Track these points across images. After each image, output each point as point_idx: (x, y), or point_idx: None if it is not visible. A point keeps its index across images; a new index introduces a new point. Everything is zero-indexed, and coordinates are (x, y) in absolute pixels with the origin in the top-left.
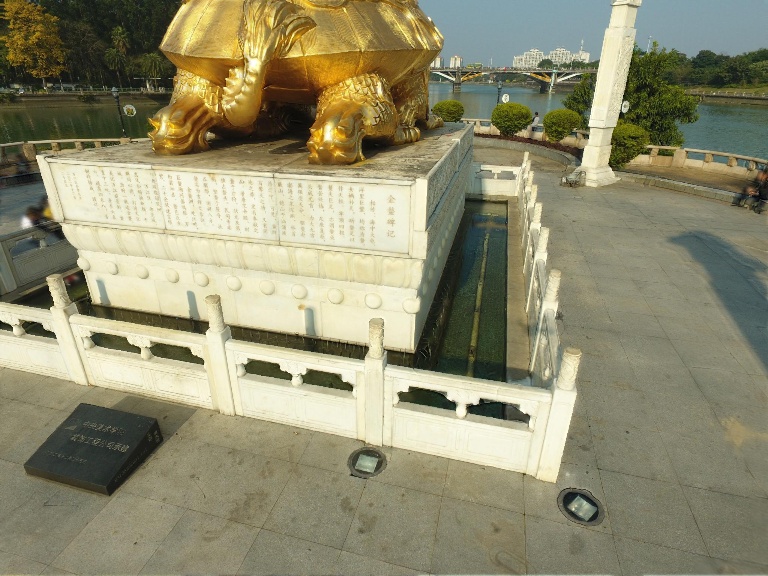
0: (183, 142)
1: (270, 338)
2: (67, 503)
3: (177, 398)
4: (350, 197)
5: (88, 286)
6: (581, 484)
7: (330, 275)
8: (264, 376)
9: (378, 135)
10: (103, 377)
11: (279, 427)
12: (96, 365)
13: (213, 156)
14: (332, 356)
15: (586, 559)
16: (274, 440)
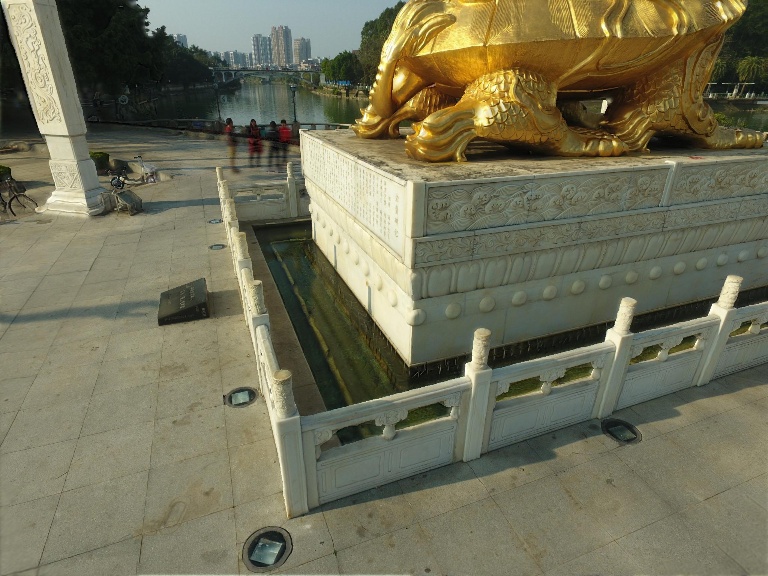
0: (372, 129)
1: None
2: (149, 318)
3: None
4: (381, 189)
5: (312, 225)
6: (300, 541)
7: None
8: None
9: (497, 138)
10: None
11: (249, 347)
12: None
13: (381, 142)
14: None
15: (199, 568)
16: (235, 351)
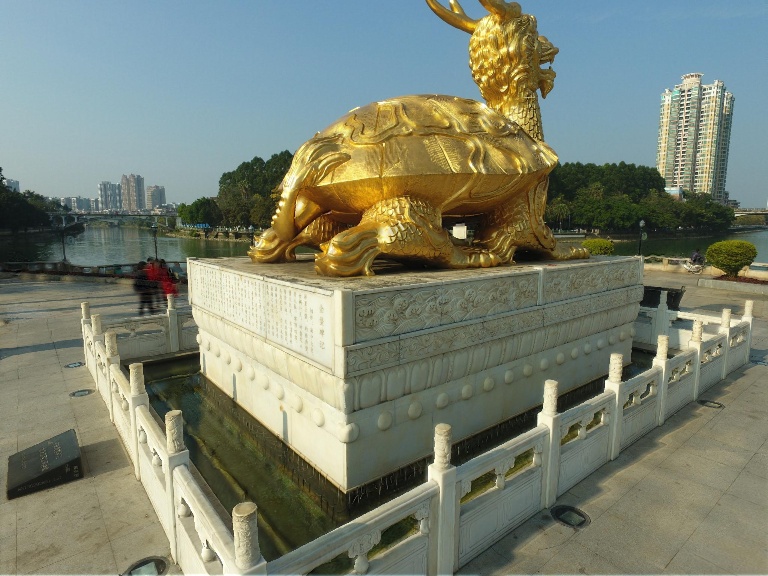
0: (269, 254)
1: (261, 433)
2: None
3: (129, 451)
4: (300, 303)
5: (200, 357)
6: None
7: (294, 380)
8: None
9: (399, 254)
10: (116, 418)
11: (146, 504)
12: (114, 407)
13: (280, 265)
14: (165, 442)
15: None
16: (127, 513)
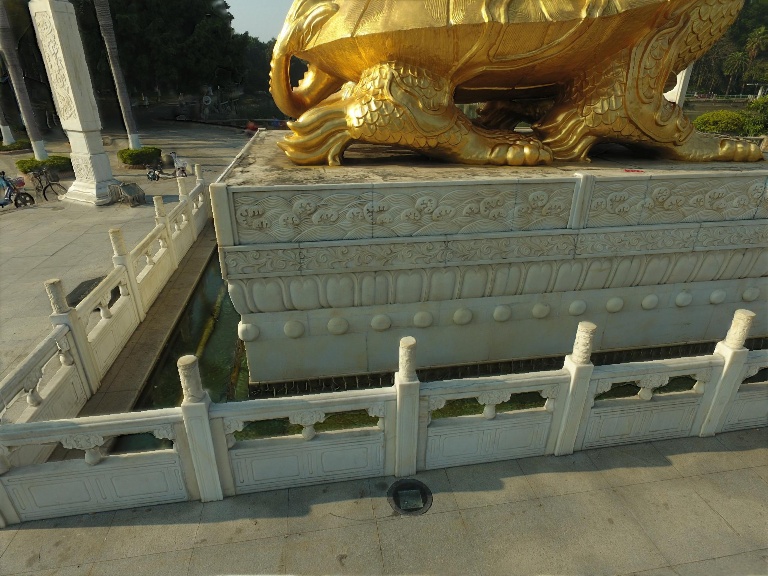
0: None
1: None
2: None
3: None
4: None
5: None
6: None
7: None
8: (122, 303)
9: (373, 141)
10: None
11: None
12: None
13: None
14: (84, 301)
15: None
16: None
